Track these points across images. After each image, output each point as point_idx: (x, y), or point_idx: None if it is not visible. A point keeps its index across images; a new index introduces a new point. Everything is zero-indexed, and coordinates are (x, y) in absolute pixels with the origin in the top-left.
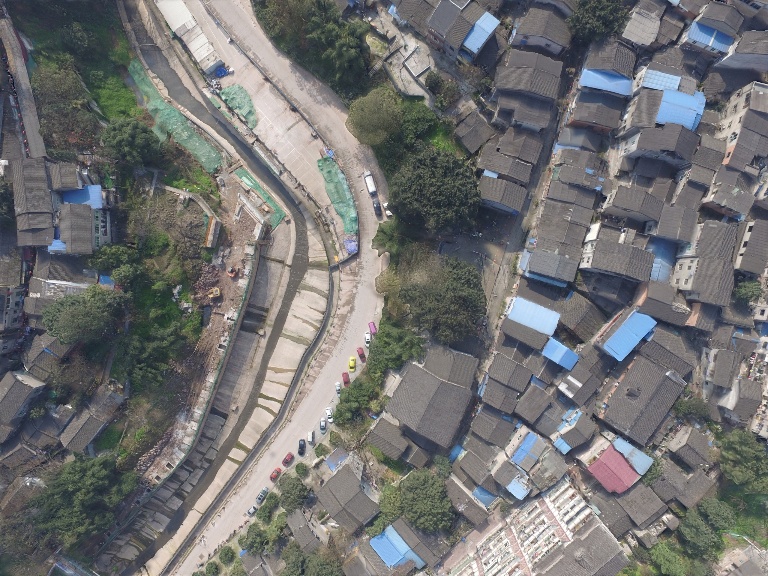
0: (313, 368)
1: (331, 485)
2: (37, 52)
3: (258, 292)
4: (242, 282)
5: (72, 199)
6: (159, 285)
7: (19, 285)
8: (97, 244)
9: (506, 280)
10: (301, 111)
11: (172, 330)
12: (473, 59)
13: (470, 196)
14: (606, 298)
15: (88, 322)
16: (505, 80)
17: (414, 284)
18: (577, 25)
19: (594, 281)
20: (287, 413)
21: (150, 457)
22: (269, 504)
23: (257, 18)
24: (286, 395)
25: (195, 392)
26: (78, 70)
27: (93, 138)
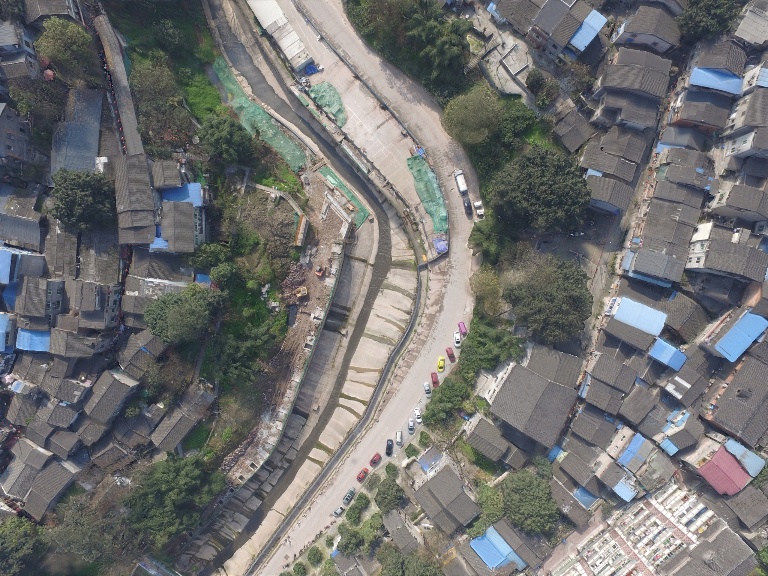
0: (401, 368)
1: (432, 486)
2: (131, 49)
3: (341, 291)
4: (329, 281)
5: (171, 197)
6: (252, 284)
7: (117, 283)
8: (196, 242)
9: (603, 280)
10: (391, 109)
11: (266, 329)
12: (577, 57)
13: (580, 195)
14: (713, 298)
15: (194, 321)
16: (614, 78)
17: (520, 284)
18: (689, 23)
19: (700, 281)
20: (373, 413)
21: (235, 457)
22: (360, 505)
23: (348, 15)
24: (373, 395)
25: (280, 392)
26: (168, 67)
27: (187, 135)
